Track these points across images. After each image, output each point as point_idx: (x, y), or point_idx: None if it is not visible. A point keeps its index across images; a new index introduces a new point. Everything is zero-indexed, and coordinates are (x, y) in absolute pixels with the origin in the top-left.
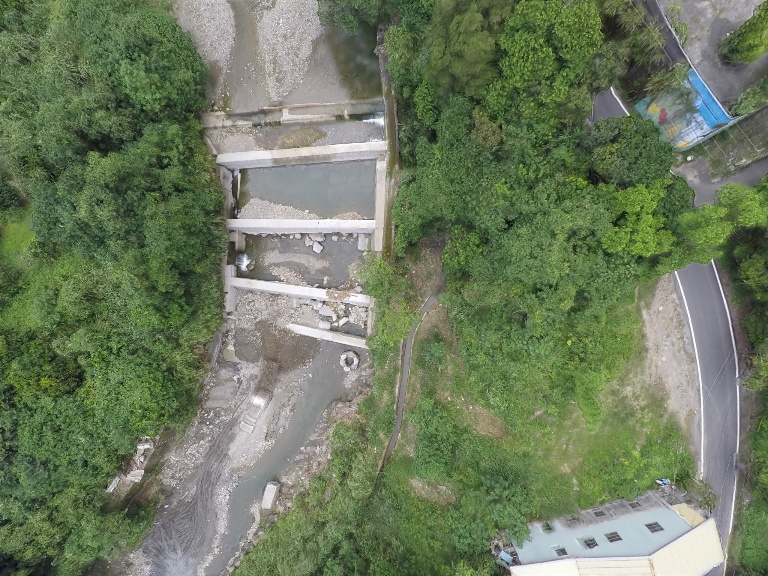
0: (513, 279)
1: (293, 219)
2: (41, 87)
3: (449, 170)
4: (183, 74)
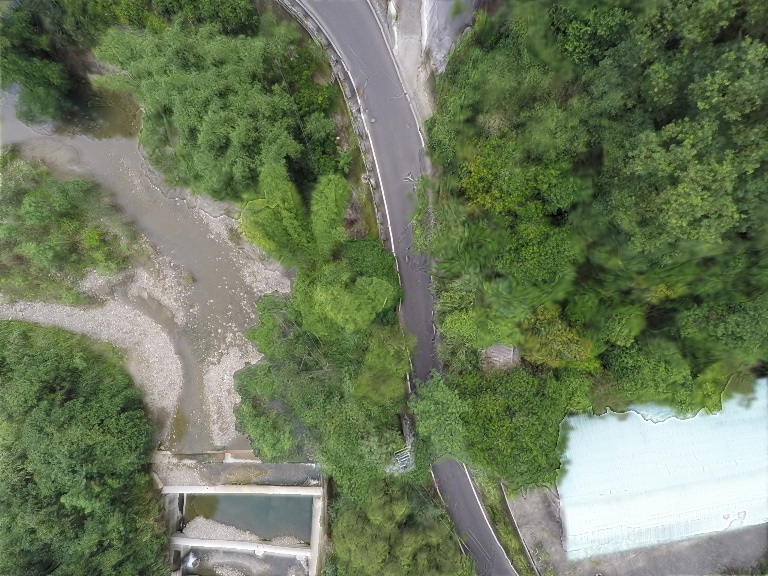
0: None
1: (234, 541)
2: None
3: None
4: (125, 460)
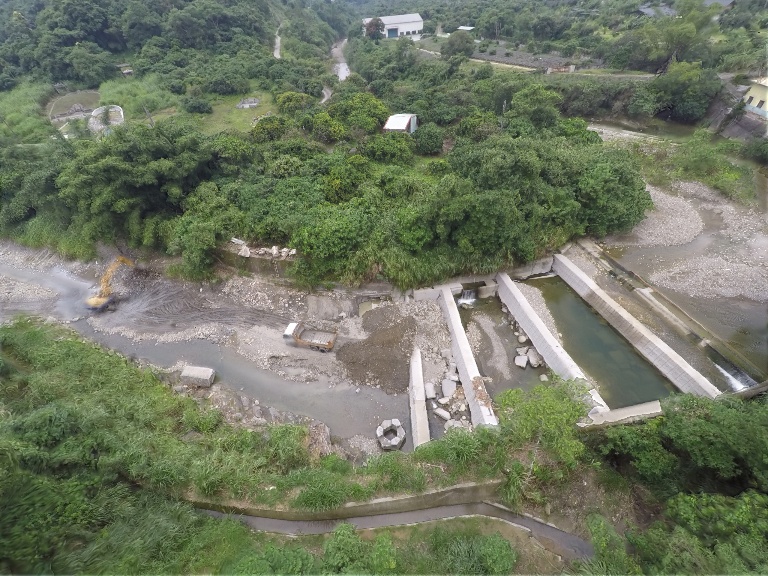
0: None
1: (544, 322)
2: None
3: None
4: (621, 206)
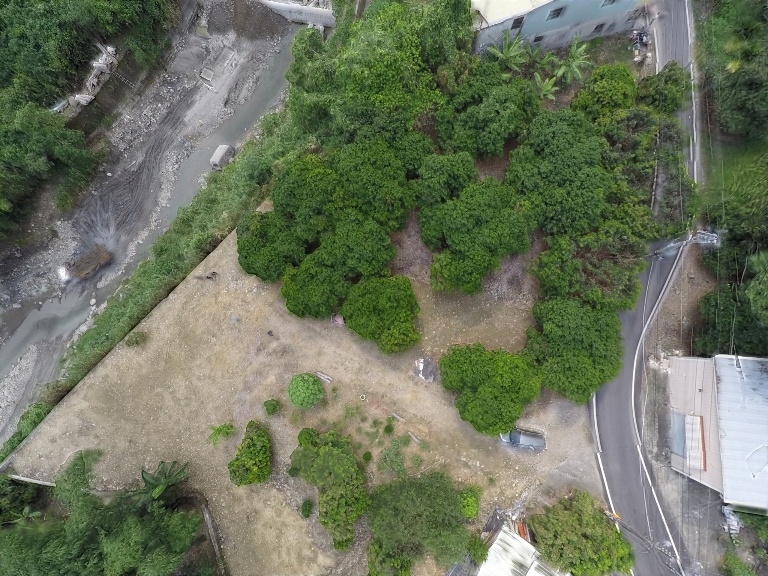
0: None
1: None
2: None
3: None
4: None
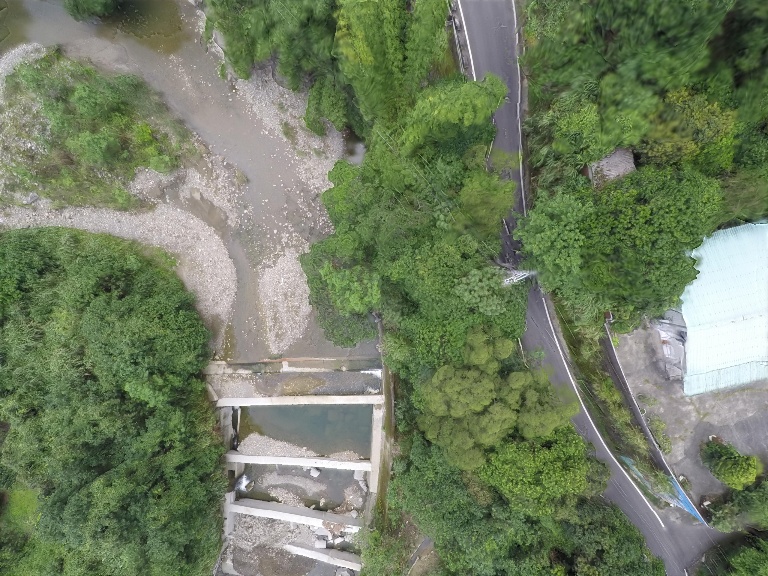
0: None
1: (291, 457)
2: (47, 372)
3: (441, 503)
4: (186, 358)
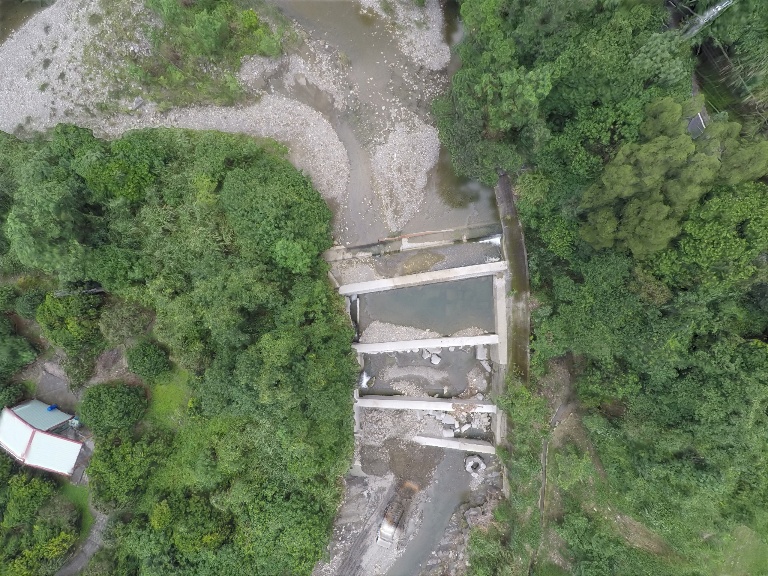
0: (701, 435)
1: (416, 340)
2: (184, 255)
3: (610, 319)
4: (319, 228)
